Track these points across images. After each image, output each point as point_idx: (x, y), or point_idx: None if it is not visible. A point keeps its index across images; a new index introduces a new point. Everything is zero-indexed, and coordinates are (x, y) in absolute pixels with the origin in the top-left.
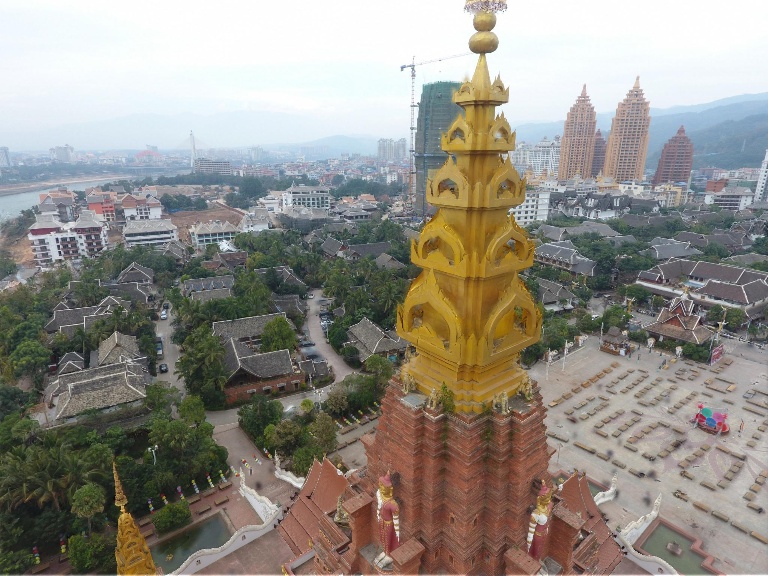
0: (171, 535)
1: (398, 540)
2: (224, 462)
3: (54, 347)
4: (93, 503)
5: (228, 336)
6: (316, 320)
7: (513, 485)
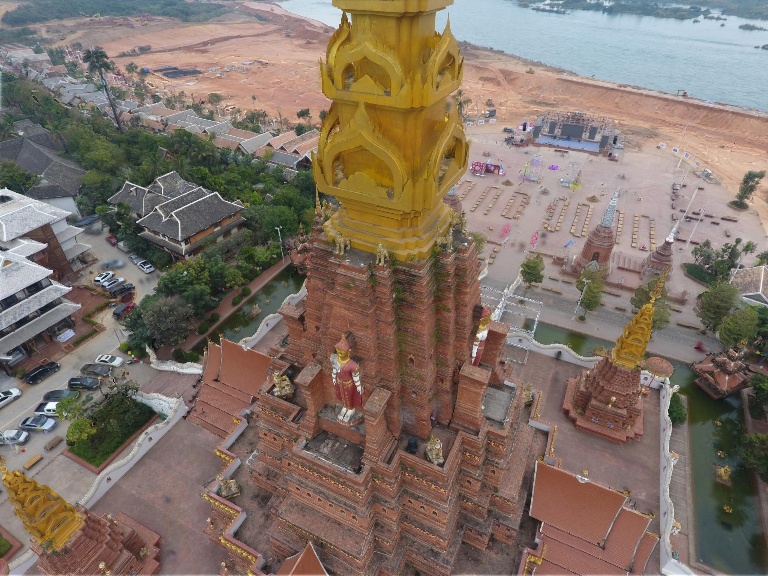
0: (767, 532)
1: None
2: None
3: None
4: None
5: None
6: None
7: None
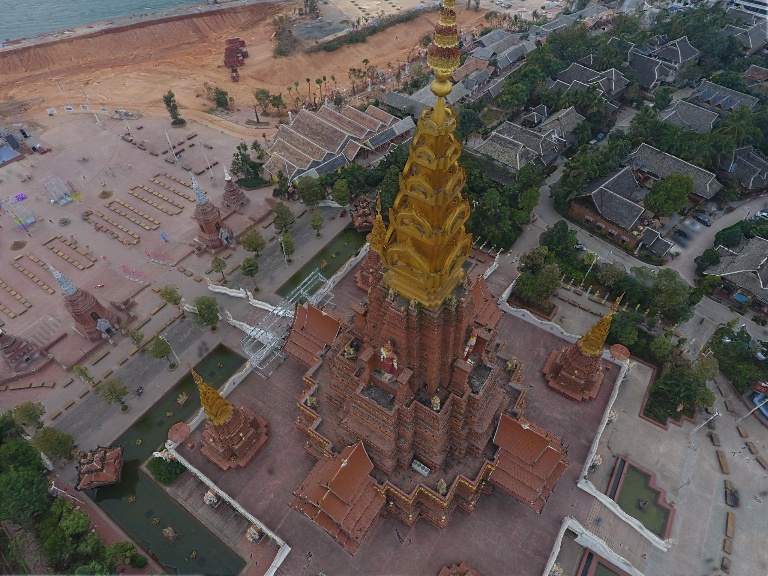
0: None
1: None
2: (507, 243)
3: (539, 95)
4: None
5: (642, 163)
6: (763, 205)
7: None
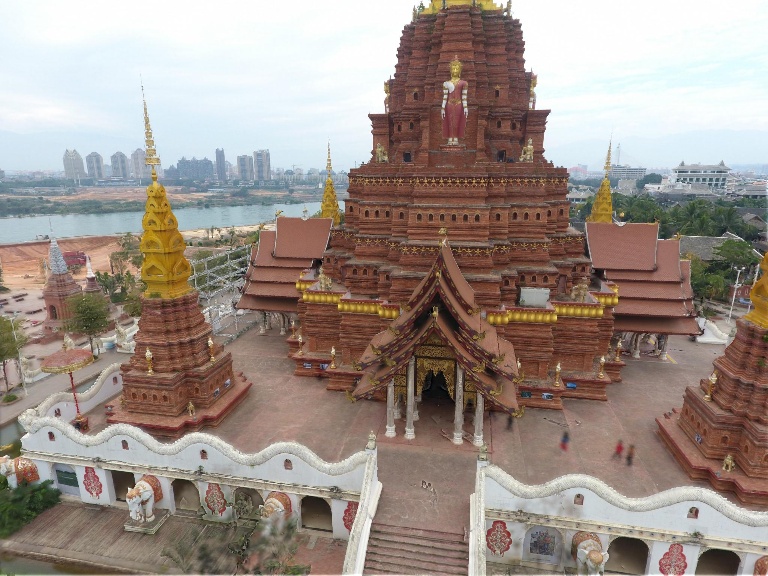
0: None
1: None
2: None
3: None
4: None
5: None
6: None
7: None
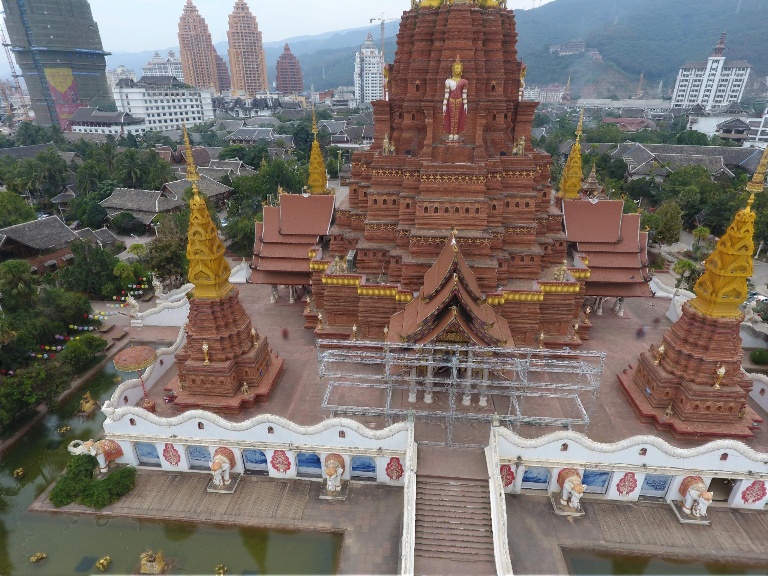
0: (93, 371)
1: (466, 112)
2: None
3: None
4: (3, 324)
5: None
6: None
7: (513, 60)
